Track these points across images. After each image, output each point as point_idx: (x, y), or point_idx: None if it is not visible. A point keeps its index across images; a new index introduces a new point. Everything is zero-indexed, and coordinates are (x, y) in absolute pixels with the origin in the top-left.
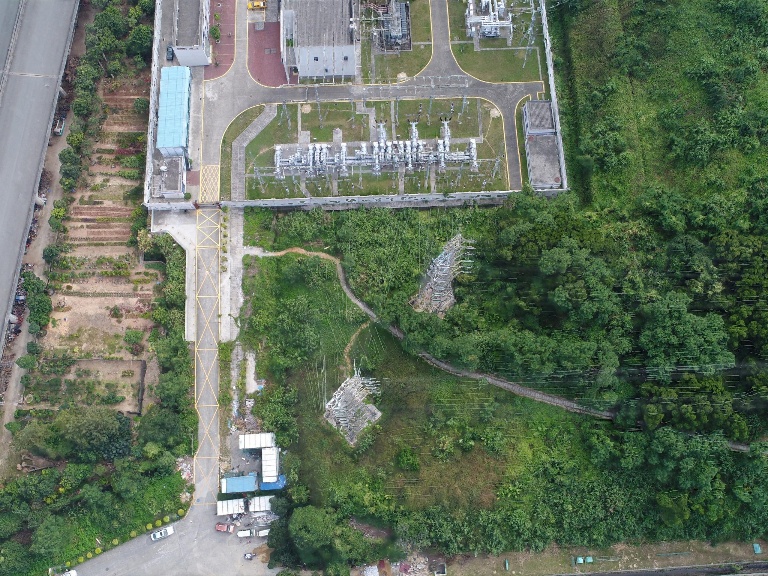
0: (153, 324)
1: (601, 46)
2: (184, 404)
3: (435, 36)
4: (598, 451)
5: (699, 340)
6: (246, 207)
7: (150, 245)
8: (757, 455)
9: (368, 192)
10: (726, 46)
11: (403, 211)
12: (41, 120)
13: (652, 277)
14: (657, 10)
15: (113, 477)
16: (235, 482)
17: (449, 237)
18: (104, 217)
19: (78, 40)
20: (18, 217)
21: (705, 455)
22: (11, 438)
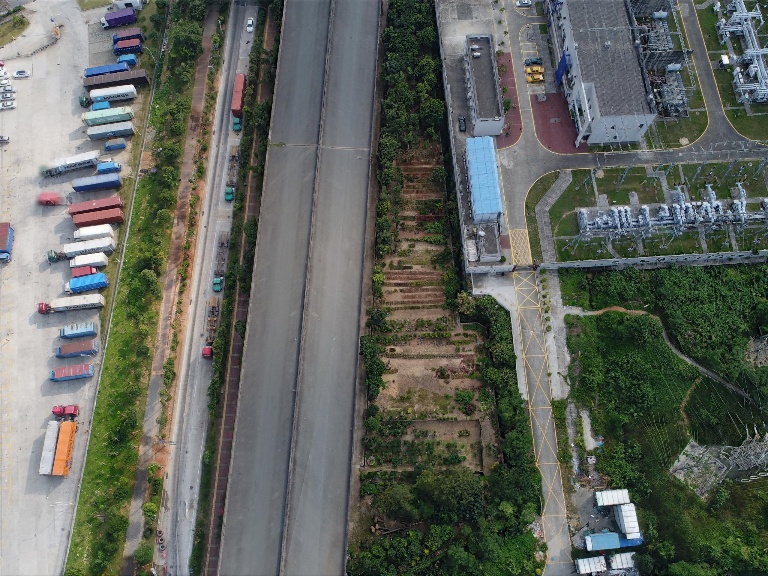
0: (480, 384)
1: None
2: (527, 462)
3: (708, 103)
4: None
5: None
6: (561, 268)
7: (473, 307)
8: None
9: (673, 251)
10: None
11: (714, 269)
12: (359, 190)
13: None
14: None
15: (471, 537)
16: (600, 539)
17: (767, 293)
18: (416, 281)
19: None
20: (352, 283)
21: None
22: (359, 501)
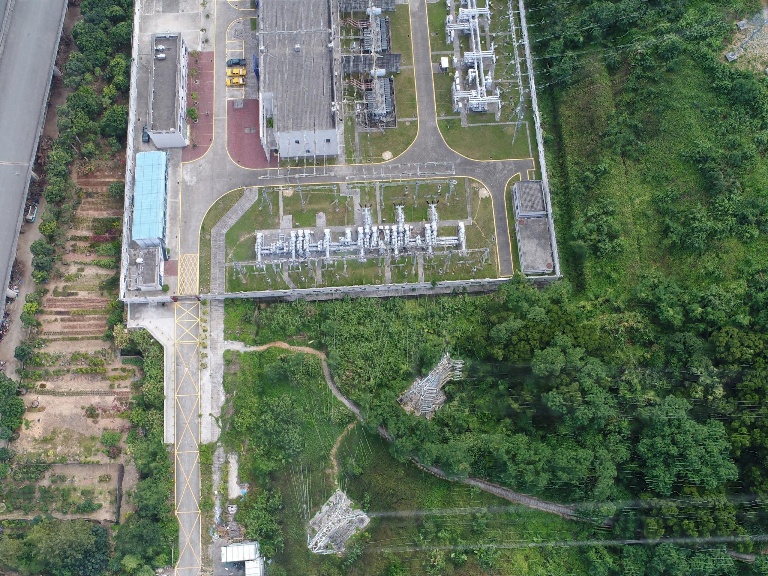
0: None
1: (592, 124)
2: (164, 511)
3: (421, 112)
4: (596, 568)
5: (700, 452)
6: (226, 299)
7: (126, 341)
8: (763, 571)
9: (353, 280)
10: (722, 128)
11: (390, 301)
12: (11, 211)
13: (650, 378)
14: (650, 89)
15: None
16: None
17: (438, 330)
18: (79, 309)
19: (51, 120)
20: None
21: (708, 572)
22: None
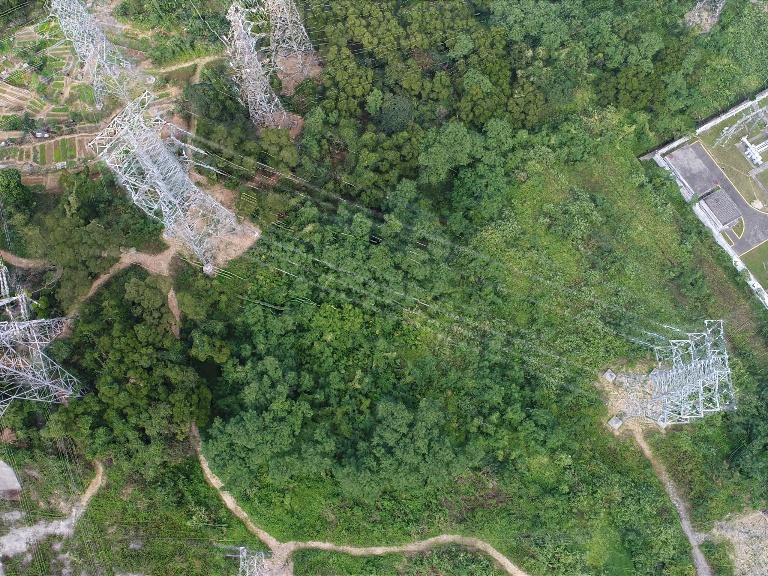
0: None
1: None
2: None
3: None
4: None
5: (527, 5)
6: None
7: None
8: None
9: None
10: None
11: None
12: None
13: None
14: None
15: None
16: None
17: None
18: None
19: None
20: None
21: None
22: None
